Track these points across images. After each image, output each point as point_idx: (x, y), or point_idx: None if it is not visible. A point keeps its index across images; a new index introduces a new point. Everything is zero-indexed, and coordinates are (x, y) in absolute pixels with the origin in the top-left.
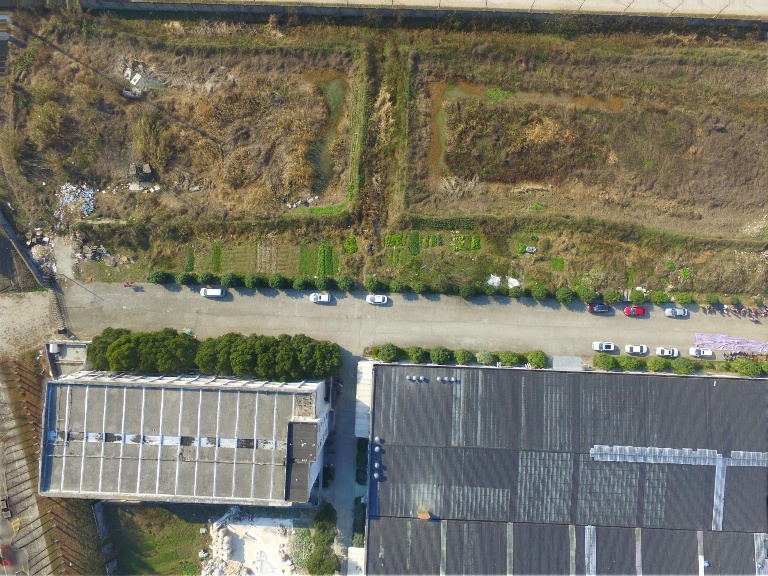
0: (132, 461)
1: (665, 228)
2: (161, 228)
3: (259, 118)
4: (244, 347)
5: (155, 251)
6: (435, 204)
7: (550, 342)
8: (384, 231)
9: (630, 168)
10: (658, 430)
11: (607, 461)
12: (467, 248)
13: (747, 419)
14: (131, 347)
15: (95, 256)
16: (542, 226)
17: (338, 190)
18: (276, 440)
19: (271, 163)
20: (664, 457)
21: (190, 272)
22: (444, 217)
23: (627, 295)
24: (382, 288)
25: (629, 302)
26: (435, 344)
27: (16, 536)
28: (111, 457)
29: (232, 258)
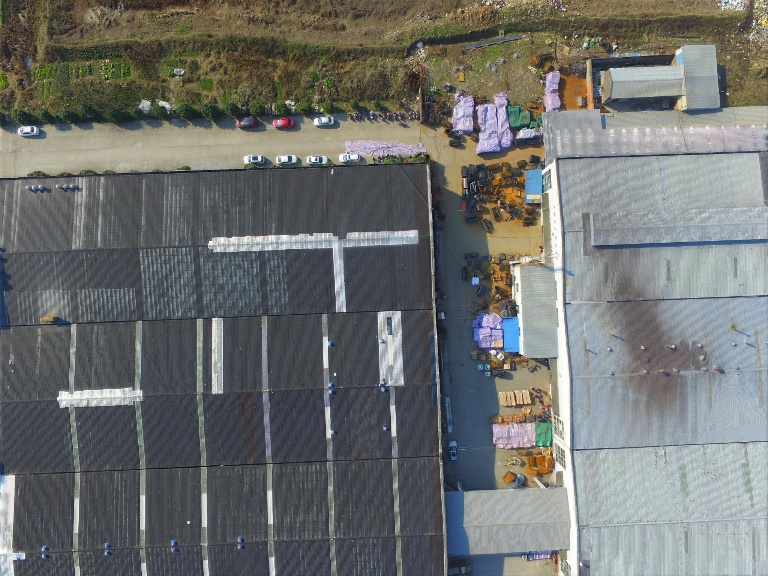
0: None
1: (308, 41)
2: None
3: None
4: None
5: None
6: (80, 34)
7: (204, 161)
8: (34, 65)
9: None
10: (276, 219)
11: (226, 252)
12: (117, 76)
13: (363, 202)
14: None
15: None
16: (189, 48)
17: None
18: None
19: None
20: (281, 244)
21: None
22: (88, 45)
23: (275, 108)
24: (31, 119)
25: (278, 115)
26: None
27: None
28: None
29: None
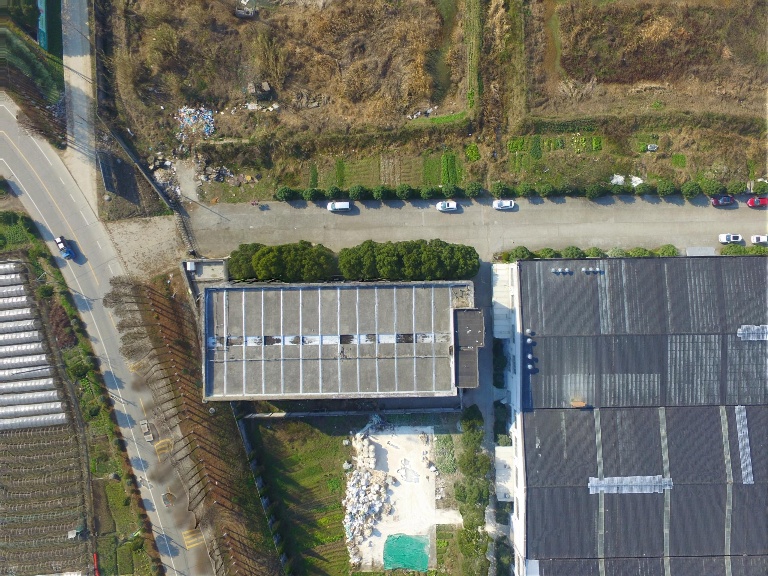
0: (293, 362)
1: None
2: (286, 143)
3: (374, 31)
4: (388, 249)
5: (278, 169)
6: (555, 107)
7: (676, 238)
8: (505, 137)
9: (745, 62)
10: None
11: (754, 340)
12: (589, 150)
13: None
14: (276, 255)
15: (219, 177)
16: (662, 124)
17: (457, 99)
18: (435, 333)
19: (388, 75)
20: None
21: (315, 188)
22: (566, 119)
23: (750, 187)
24: (508, 193)
25: (752, 194)
26: (564, 246)
27: (174, 449)
28: (272, 359)
29: (356, 172)
